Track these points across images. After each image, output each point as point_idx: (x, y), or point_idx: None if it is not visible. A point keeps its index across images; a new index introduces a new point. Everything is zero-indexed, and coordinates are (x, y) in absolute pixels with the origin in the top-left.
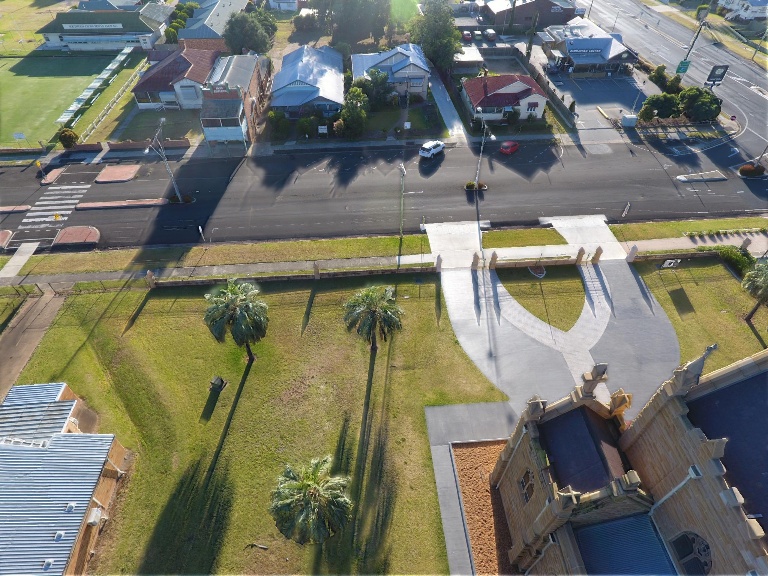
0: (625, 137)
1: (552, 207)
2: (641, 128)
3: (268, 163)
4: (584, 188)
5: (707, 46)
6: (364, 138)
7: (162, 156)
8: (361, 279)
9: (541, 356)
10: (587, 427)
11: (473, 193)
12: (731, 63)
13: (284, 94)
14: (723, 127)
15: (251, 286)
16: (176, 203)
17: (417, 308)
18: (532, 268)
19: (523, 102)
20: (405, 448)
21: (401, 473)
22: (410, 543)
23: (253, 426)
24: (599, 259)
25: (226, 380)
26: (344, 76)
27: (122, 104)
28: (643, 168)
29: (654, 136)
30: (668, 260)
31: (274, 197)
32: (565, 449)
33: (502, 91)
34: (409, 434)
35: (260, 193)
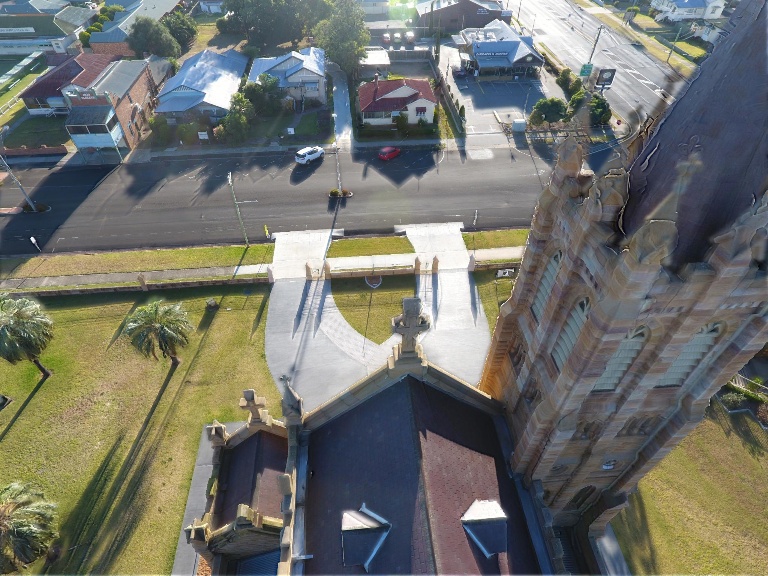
0: (512, 142)
1: (412, 214)
2: (531, 133)
3: (141, 170)
4: (450, 195)
5: (627, 48)
6: (247, 144)
7: (2, 165)
8: (190, 290)
9: (344, 370)
10: (255, 454)
11: (336, 200)
12: (645, 66)
13: (170, 99)
14: (613, 131)
15: (28, 301)
16: (30, 212)
17: (235, 320)
18: (369, 278)
19: (411, 107)
20: (168, 468)
21: (154, 495)
22: (136, 570)
23: (22, 446)
24: (439, 268)
25: (12, 397)
26: (241, 81)
27: (15, 110)
28: (517, 174)
29: (541, 141)
30: (501, 270)
31: (132, 205)
32: (236, 477)
33: (390, 96)
34: (178, 453)
35: (119, 201)
